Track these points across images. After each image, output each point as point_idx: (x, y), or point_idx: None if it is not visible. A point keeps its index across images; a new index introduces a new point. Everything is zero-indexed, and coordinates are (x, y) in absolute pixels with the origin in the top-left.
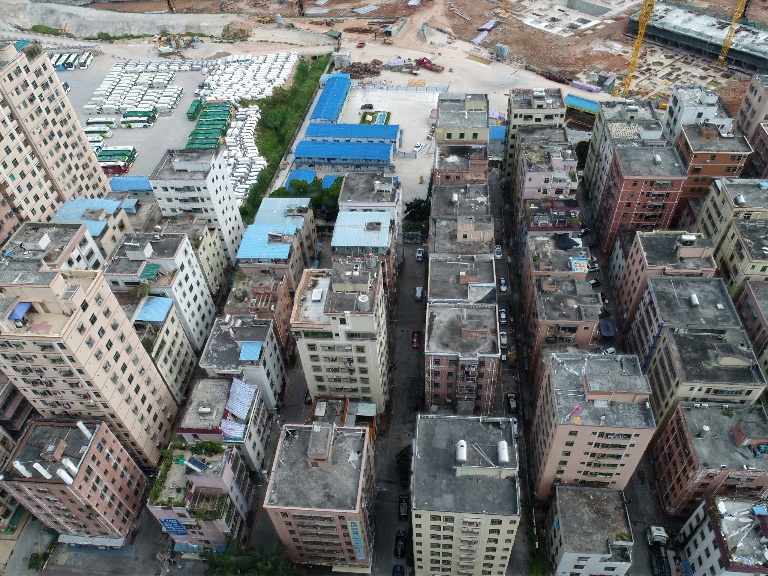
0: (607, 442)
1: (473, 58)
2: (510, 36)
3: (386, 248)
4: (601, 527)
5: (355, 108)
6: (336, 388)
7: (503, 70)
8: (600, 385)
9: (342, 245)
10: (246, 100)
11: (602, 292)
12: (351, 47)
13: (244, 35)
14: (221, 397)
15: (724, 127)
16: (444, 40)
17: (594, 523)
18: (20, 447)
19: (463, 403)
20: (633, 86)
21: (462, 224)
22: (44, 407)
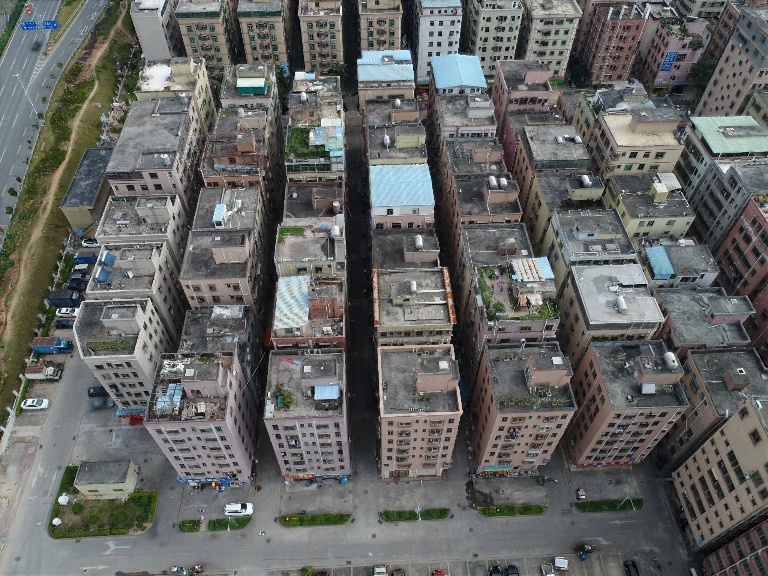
0: None
1: None
2: None
3: None
4: None
5: None
6: (708, 13)
7: None
8: None
9: None
10: None
11: None
12: None
13: None
14: None
15: None
16: None
17: None
18: None
19: None
20: None
21: None
22: (596, 0)
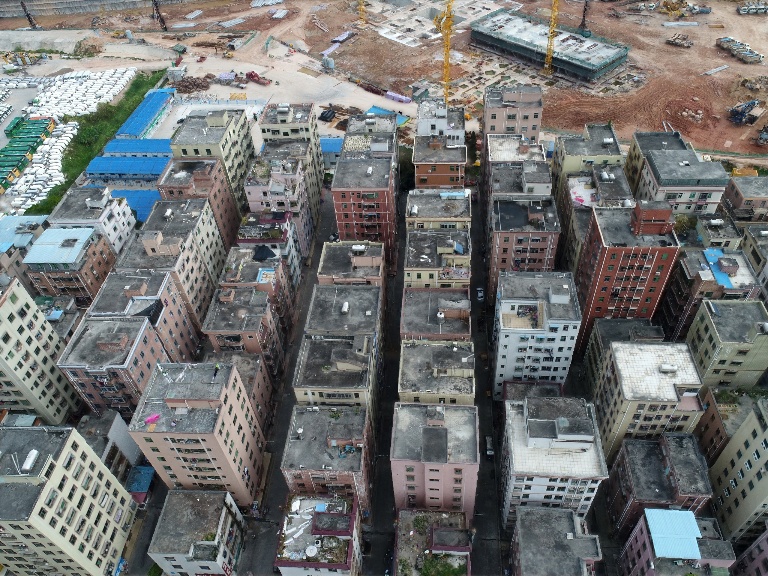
0: (185, 447)
1: (304, 71)
2: (360, 47)
3: (77, 264)
4: (194, 528)
5: (172, 122)
6: None
7: (327, 82)
8: (177, 393)
9: (32, 262)
10: (69, 116)
11: None
12: (192, 61)
13: (95, 51)
14: None
15: (459, 138)
16: (284, 53)
17: (189, 524)
18: None
19: (107, 413)
20: (459, 95)
21: (145, 239)
22: None
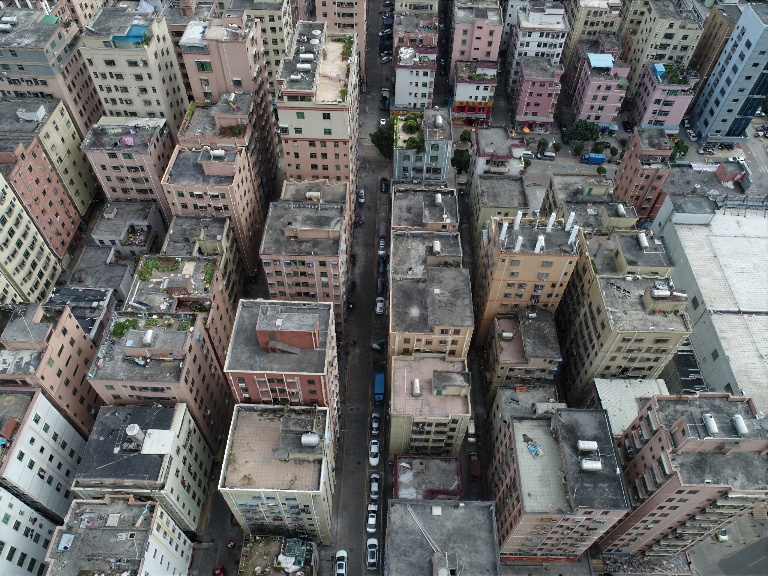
0: (343, 11)
1: None
2: None
3: None
4: None
5: None
6: None
7: None
8: None
9: None
10: None
11: (393, 8)
12: None
13: None
14: (134, 7)
15: None
16: None
17: None
18: (15, 5)
19: None
20: None
21: None
22: None
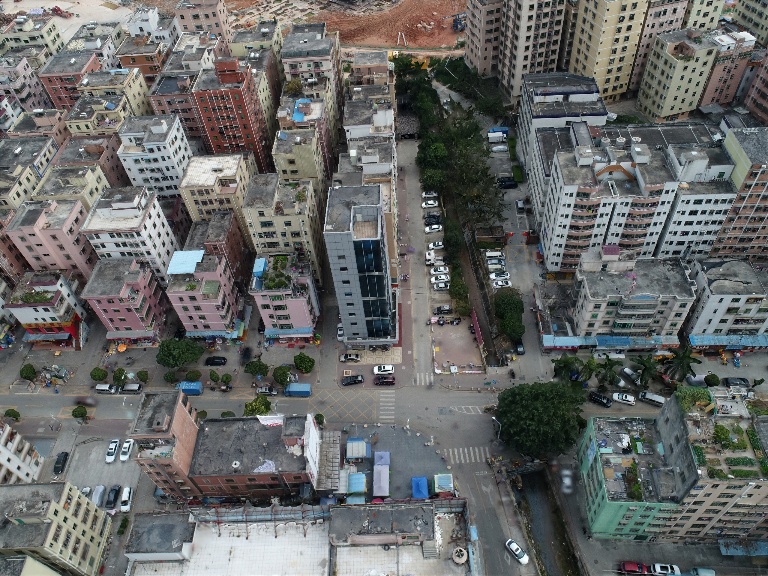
0: None
1: (106, 5)
2: None
3: None
4: None
5: None
6: None
7: (122, 13)
8: None
9: None
10: None
11: None
12: (10, 2)
13: None
14: None
15: (165, 38)
16: None
17: None
18: None
19: None
20: (243, 21)
21: None
22: None
